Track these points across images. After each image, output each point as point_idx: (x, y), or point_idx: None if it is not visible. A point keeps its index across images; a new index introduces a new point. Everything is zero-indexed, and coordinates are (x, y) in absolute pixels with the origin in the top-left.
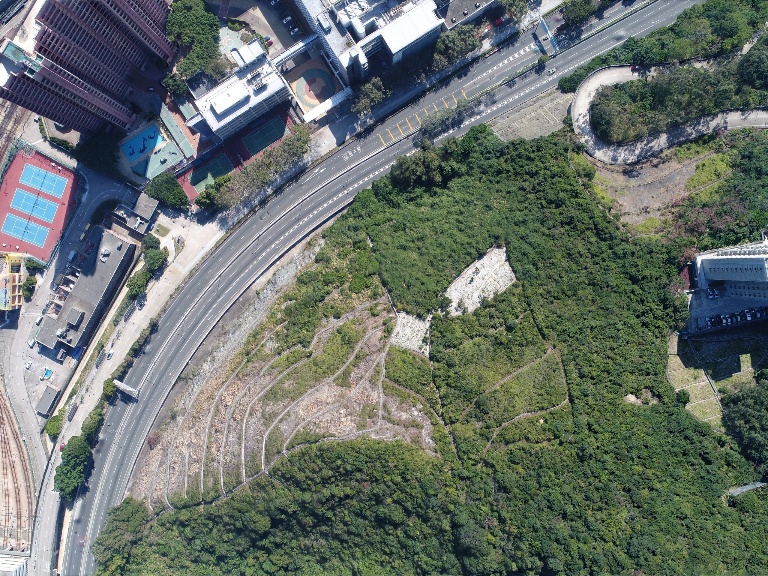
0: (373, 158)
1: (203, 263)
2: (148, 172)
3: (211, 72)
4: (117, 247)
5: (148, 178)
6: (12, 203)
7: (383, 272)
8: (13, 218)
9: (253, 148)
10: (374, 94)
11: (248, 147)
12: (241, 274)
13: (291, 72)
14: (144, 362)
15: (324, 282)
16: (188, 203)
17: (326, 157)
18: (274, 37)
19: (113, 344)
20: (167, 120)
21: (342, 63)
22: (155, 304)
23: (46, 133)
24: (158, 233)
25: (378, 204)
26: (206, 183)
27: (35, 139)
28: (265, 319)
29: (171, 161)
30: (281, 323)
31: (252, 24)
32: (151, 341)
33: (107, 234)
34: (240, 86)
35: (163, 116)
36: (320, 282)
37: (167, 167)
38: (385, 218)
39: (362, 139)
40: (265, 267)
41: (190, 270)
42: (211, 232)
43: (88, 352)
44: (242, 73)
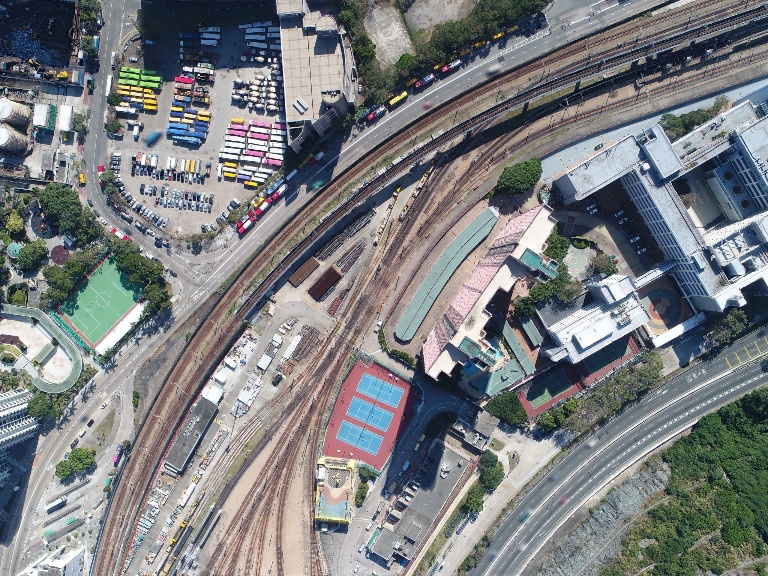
0: (718, 381)
1: (539, 481)
2: (488, 389)
3: (565, 298)
4: (457, 464)
5: (488, 394)
6: (348, 411)
7: (763, 526)
8: (348, 425)
9: (593, 366)
10: (737, 327)
11: (587, 365)
12: (575, 492)
13: (636, 291)
14: (475, 575)
15: (692, 527)
16: (526, 420)
17: (670, 379)
18: (619, 256)
19: (444, 556)
20: (509, 337)
21: (719, 305)
22: (487, 517)
23: (387, 345)
24: (493, 447)
25: (728, 432)
26: (543, 399)
27: (374, 349)
28: (623, 556)
29: (512, 379)
30: (646, 566)
31: (597, 242)
32: (483, 555)
33: (448, 451)
34: (607, 322)
35: (506, 333)
36: (687, 526)
37: (508, 385)
38: (741, 452)
39: (707, 361)
40: (600, 486)
41: (523, 485)
42: (546, 448)
43: (416, 560)
44: (606, 306)
